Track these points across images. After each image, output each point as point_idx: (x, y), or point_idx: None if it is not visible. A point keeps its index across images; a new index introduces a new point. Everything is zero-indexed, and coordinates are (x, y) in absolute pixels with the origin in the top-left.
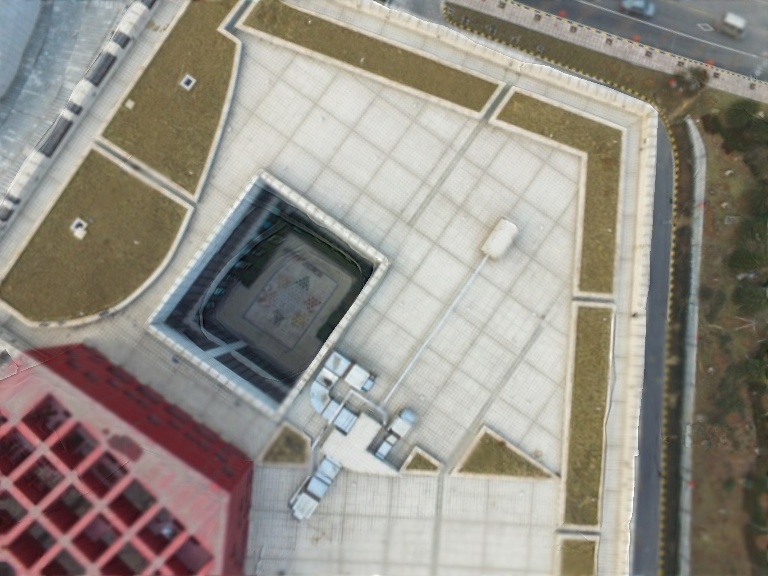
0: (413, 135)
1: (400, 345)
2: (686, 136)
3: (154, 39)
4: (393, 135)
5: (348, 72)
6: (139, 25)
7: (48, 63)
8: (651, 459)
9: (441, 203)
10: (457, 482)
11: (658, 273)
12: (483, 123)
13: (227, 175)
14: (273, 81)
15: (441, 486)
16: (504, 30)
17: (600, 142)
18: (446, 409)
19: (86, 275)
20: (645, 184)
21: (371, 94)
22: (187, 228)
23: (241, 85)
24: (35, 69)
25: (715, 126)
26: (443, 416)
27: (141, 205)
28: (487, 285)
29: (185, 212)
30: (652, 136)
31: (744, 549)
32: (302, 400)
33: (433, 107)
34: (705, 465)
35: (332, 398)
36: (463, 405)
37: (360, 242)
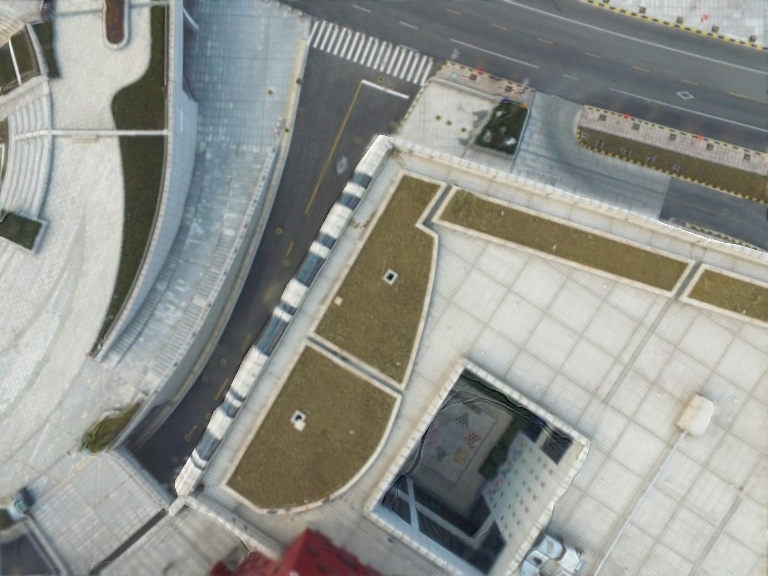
0: (604, 314)
1: (602, 520)
2: None
3: (355, 235)
4: (585, 315)
5: (540, 258)
6: (344, 227)
7: (207, 211)
8: None
9: (635, 380)
10: None
11: None
12: (673, 300)
13: (429, 362)
14: (468, 269)
15: None
16: (639, 151)
17: None
18: None
19: (307, 464)
20: None
21: (562, 277)
22: (396, 416)
23: (439, 276)
24: (196, 218)
25: None
26: None
27: (353, 396)
28: (684, 459)
29: (394, 401)
30: None
31: None
32: None
33: (623, 286)
34: None
35: None
36: None
37: (564, 427)
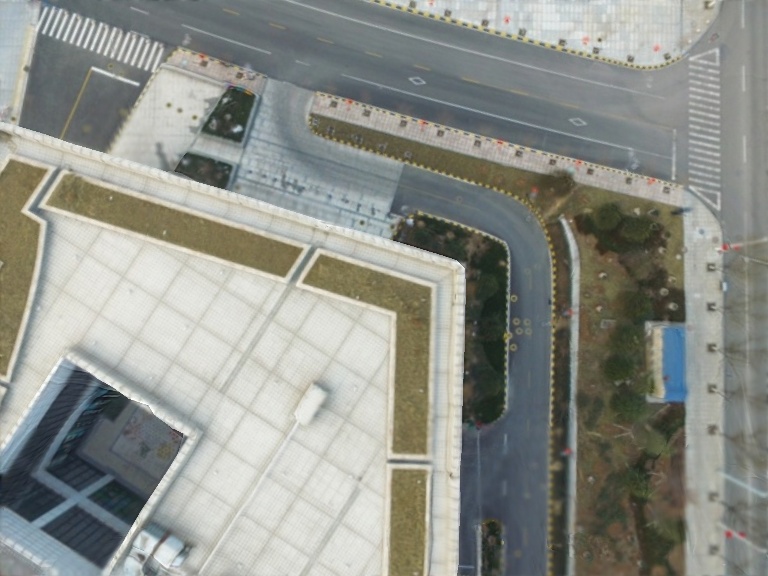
0: (222, 302)
1: (215, 514)
2: (561, 236)
3: None
4: (201, 303)
5: (152, 244)
6: None
7: None
8: (536, 568)
9: (252, 369)
10: None
11: (539, 377)
12: (291, 286)
13: (39, 353)
14: (80, 257)
15: None
16: (370, 138)
17: (408, 302)
18: None
19: None
20: (455, 343)
21: (178, 264)
22: None
23: (48, 263)
24: None
25: (587, 227)
26: None
27: None
28: (301, 450)
29: None
30: (460, 294)
31: None
32: (117, 575)
33: (240, 273)
34: None
35: (145, 573)
36: (281, 571)
37: (166, 418)
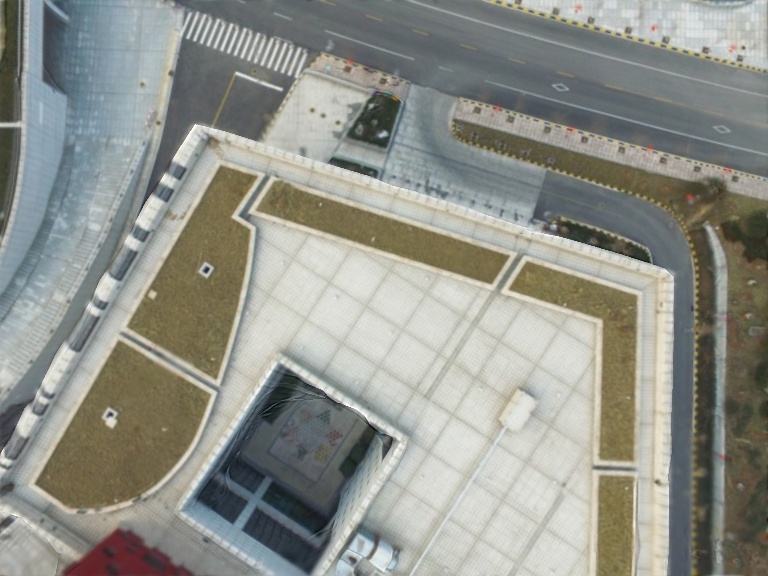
0: (426, 308)
1: (422, 518)
2: (705, 242)
3: (172, 228)
4: (407, 309)
5: (360, 251)
6: (157, 219)
7: (73, 205)
8: (681, 574)
9: (457, 374)
10: None
11: (681, 383)
12: (496, 293)
13: (247, 357)
14: (287, 262)
15: None
16: (514, 144)
17: (615, 309)
18: None
19: (118, 462)
20: (663, 350)
21: (383, 270)
22: (211, 412)
23: (257, 269)
24: (61, 212)
25: (735, 234)
26: None
27: (167, 392)
28: (506, 455)
29: (209, 397)
30: (668, 302)
31: None
32: None
33: (445, 279)
34: None
35: None
36: (487, 575)
37: (378, 423)
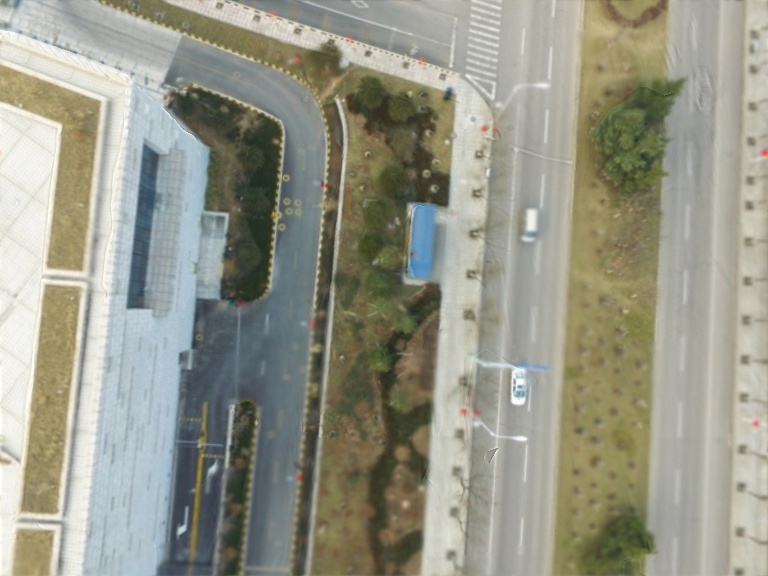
0: None
1: None
2: (336, 117)
3: None
4: None
5: None
6: None
7: None
8: (288, 450)
9: None
10: None
11: (305, 258)
12: None
13: None
14: None
15: None
16: (147, 6)
17: (73, 113)
18: None
19: None
20: None
21: None
22: None
23: None
24: None
25: (357, 106)
26: None
27: None
28: None
29: None
30: (126, 106)
31: (365, 543)
32: None
33: None
34: (332, 456)
35: None
36: None
37: None
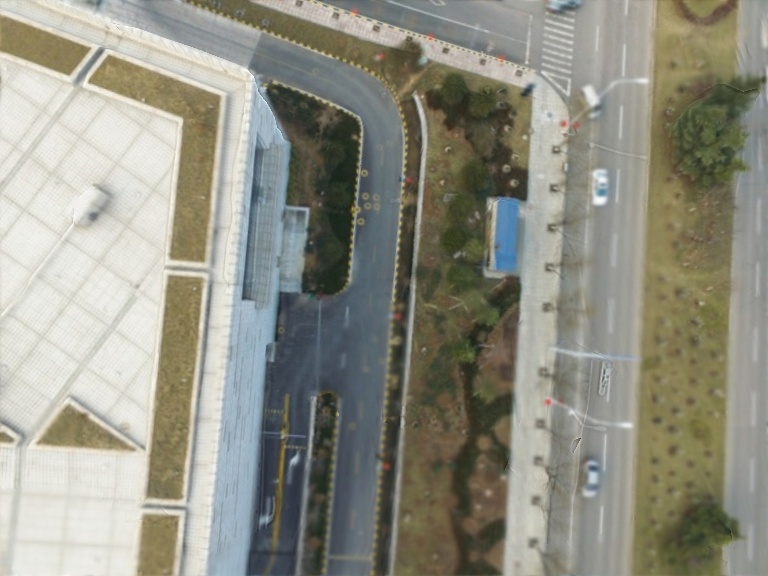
0: (4, 99)
1: None
2: (414, 112)
3: None
4: None
5: None
6: None
7: None
8: (369, 441)
9: (32, 169)
10: (35, 454)
11: (384, 252)
12: (78, 87)
13: None
14: None
15: (19, 458)
16: (228, 3)
17: (194, 107)
18: (30, 380)
19: None
20: (239, 150)
21: None
22: None
23: None
24: None
25: (436, 102)
26: (26, 387)
27: None
28: (77, 253)
29: None
30: (246, 101)
31: (449, 532)
32: None
33: (26, 70)
34: (415, 446)
35: None
36: (48, 376)
37: None
